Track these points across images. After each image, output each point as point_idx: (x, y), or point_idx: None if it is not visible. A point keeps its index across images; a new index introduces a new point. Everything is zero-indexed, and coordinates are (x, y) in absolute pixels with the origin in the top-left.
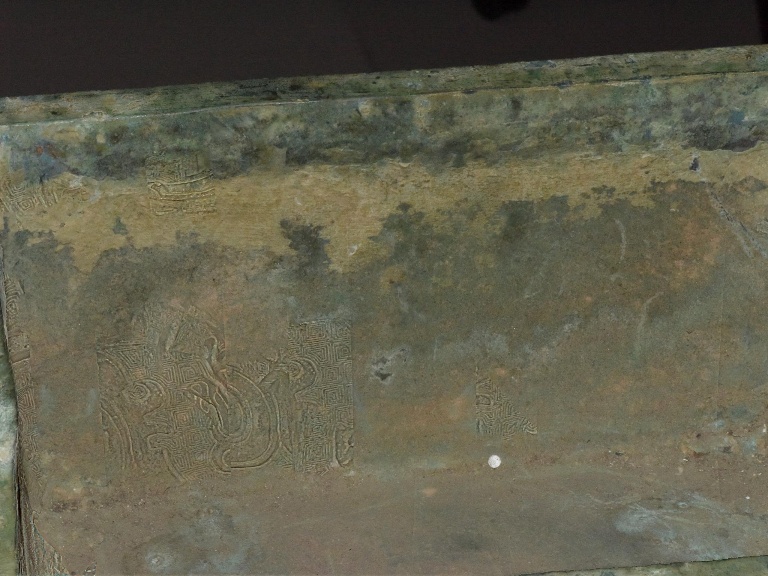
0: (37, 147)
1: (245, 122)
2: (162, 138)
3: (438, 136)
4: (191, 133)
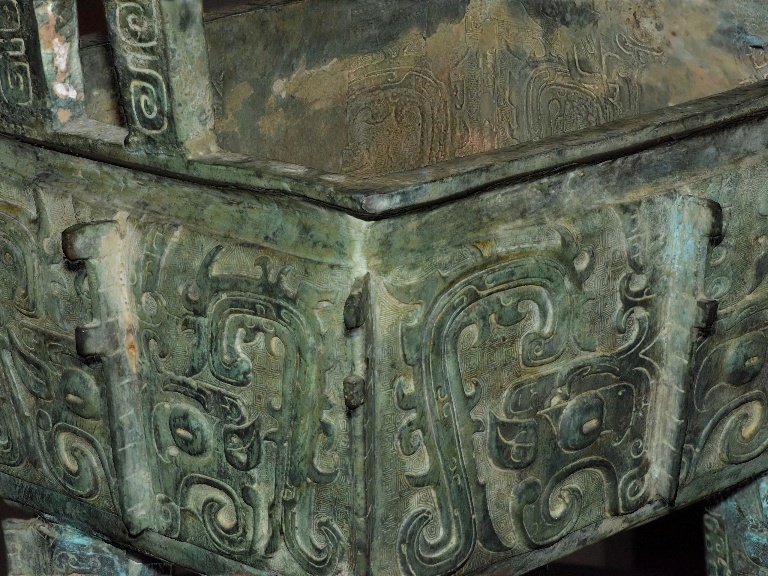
0: None
1: None
2: None
3: (651, 152)
4: None
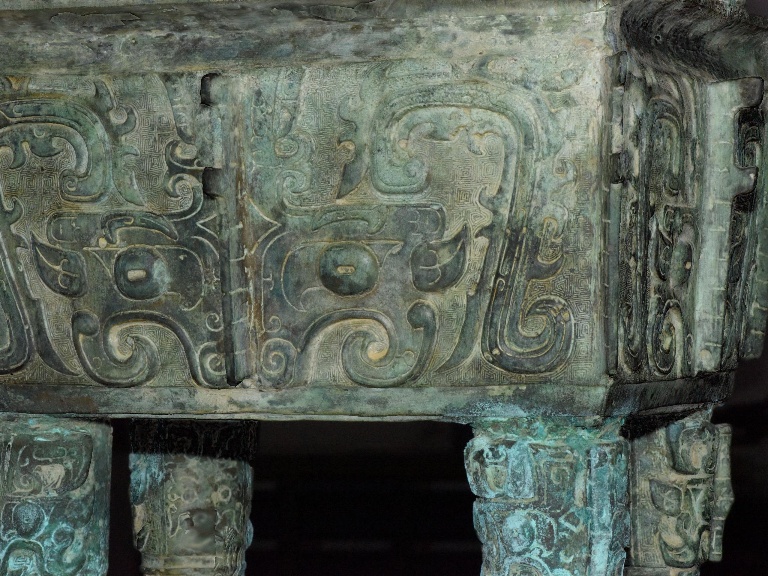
0: (558, 1)
1: (376, 2)
2: (449, 7)
3: (218, 36)
4: (423, 6)
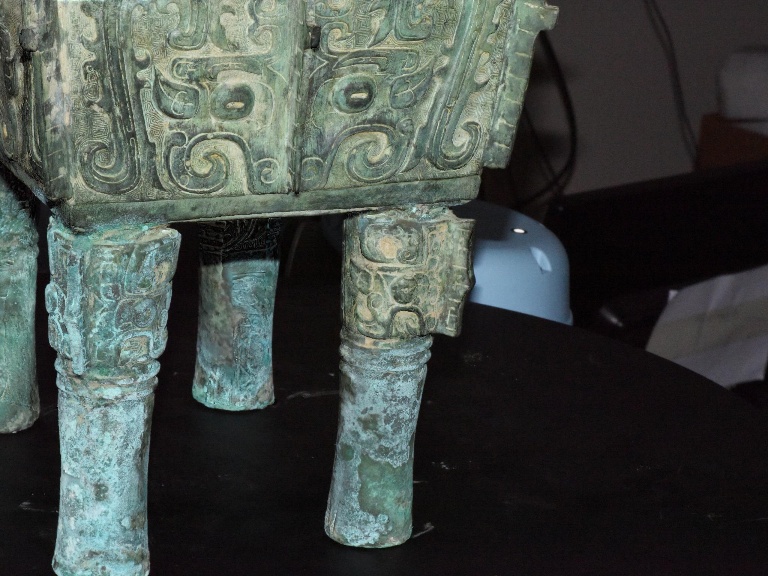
0: None
1: None
2: None
3: None
4: None
